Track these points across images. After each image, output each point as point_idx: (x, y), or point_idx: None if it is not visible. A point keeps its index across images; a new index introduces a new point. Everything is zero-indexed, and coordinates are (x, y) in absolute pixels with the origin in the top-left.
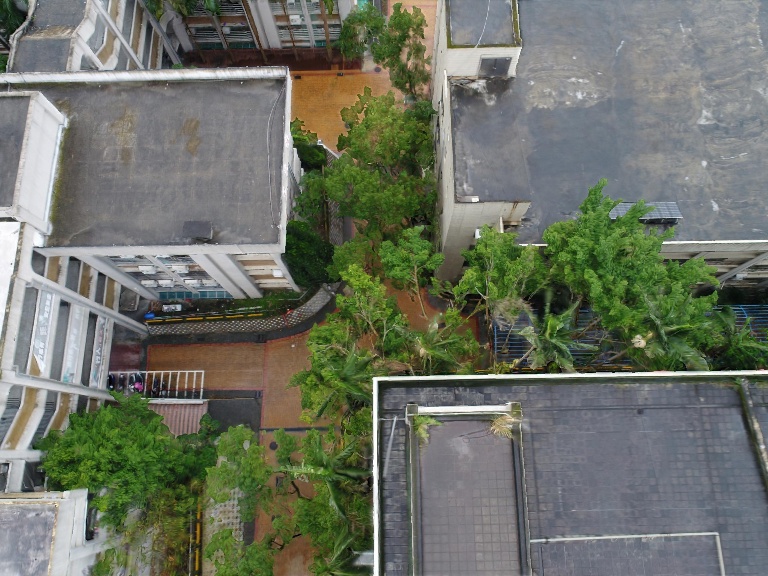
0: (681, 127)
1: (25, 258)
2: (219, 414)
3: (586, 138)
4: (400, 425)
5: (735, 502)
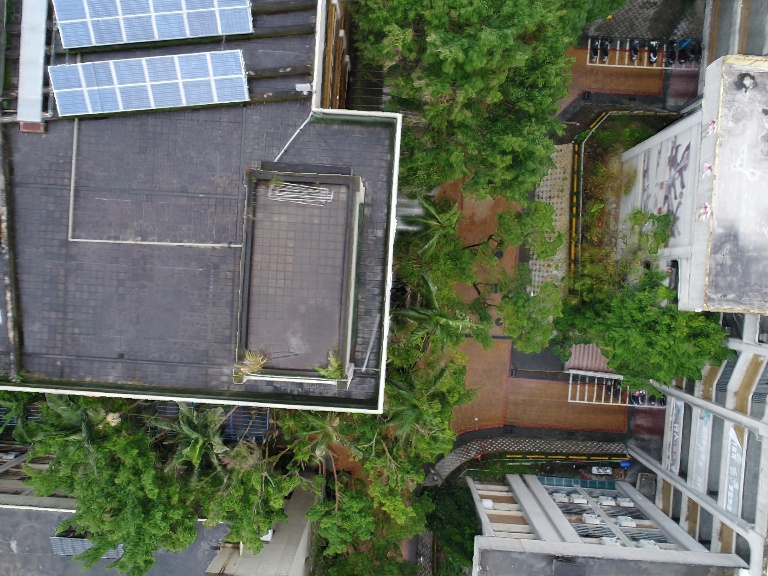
0: None
1: (757, 559)
2: (553, 357)
3: None
4: (360, 362)
5: (47, 266)
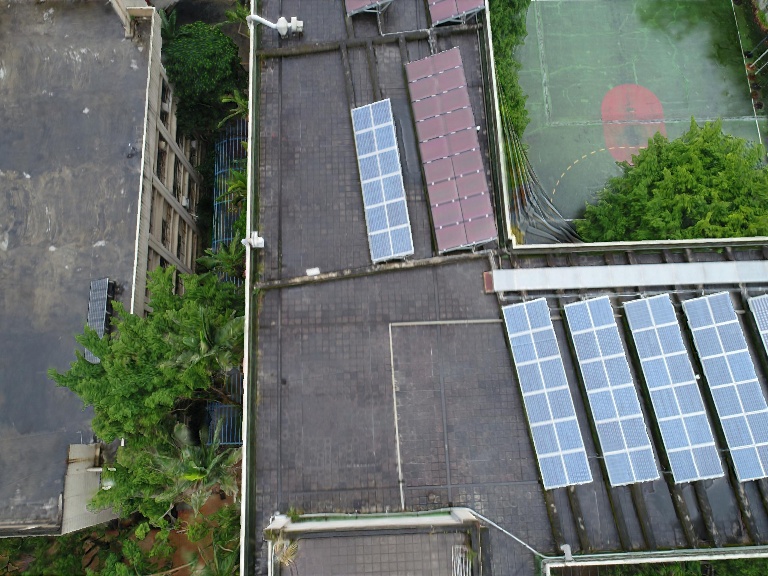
0: (8, 267)
1: None
2: None
3: (6, 367)
4: None
5: (364, 305)
